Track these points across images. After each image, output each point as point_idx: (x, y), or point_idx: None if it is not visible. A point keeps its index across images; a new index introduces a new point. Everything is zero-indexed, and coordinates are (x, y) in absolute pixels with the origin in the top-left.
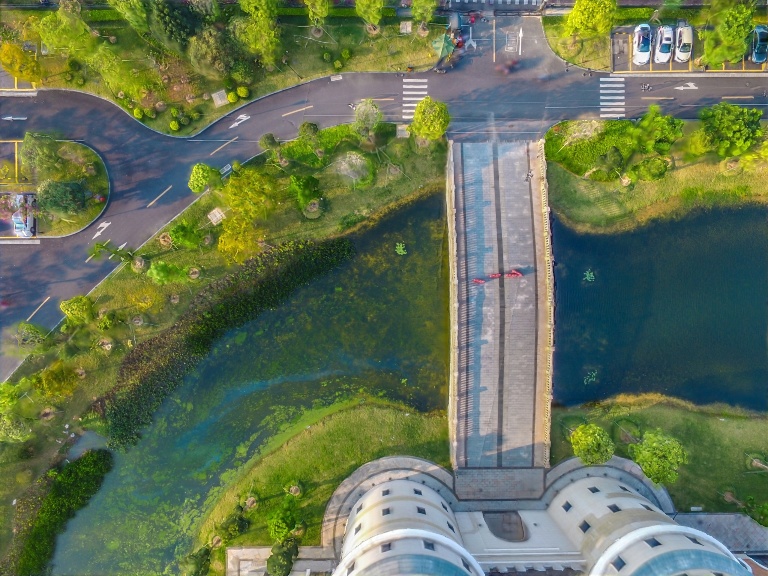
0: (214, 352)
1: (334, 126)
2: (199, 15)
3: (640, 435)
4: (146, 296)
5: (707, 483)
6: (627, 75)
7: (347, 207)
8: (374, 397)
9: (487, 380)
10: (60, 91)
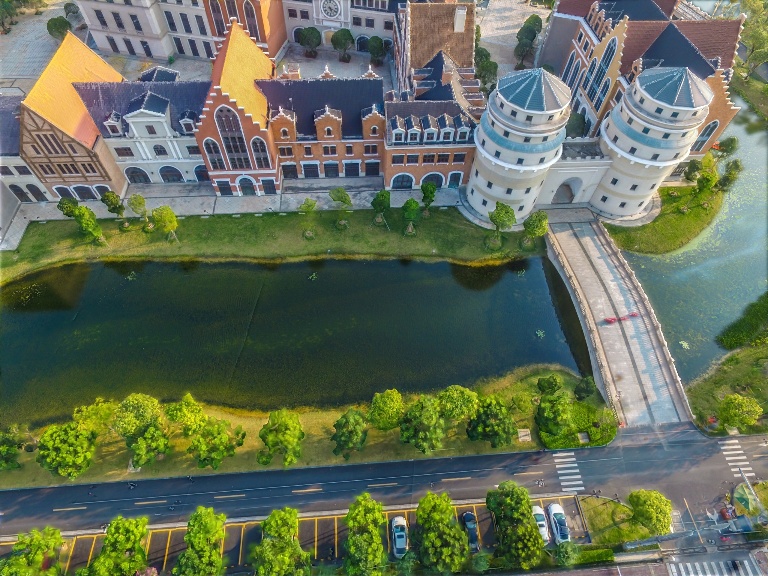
0: None
1: None
2: None
3: (485, 242)
4: None
5: (439, 220)
6: (561, 494)
7: (741, 369)
8: (658, 258)
9: (600, 262)
10: None
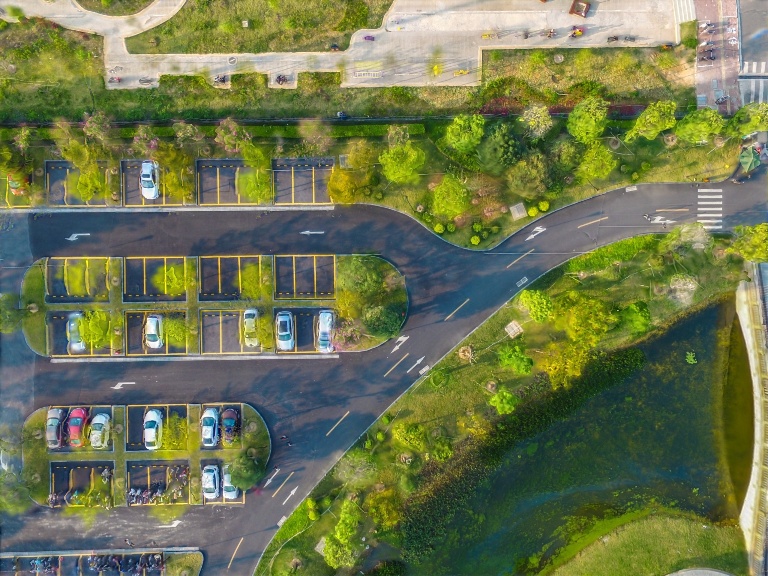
0: (506, 463)
1: (630, 237)
2: (526, 139)
3: None
4: (474, 421)
5: None
6: None
7: None
8: (666, 507)
9: None
10: (358, 205)
